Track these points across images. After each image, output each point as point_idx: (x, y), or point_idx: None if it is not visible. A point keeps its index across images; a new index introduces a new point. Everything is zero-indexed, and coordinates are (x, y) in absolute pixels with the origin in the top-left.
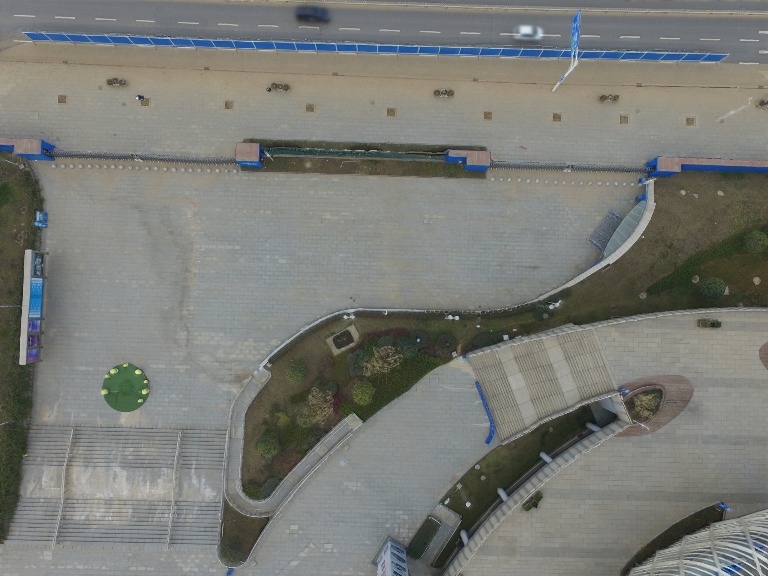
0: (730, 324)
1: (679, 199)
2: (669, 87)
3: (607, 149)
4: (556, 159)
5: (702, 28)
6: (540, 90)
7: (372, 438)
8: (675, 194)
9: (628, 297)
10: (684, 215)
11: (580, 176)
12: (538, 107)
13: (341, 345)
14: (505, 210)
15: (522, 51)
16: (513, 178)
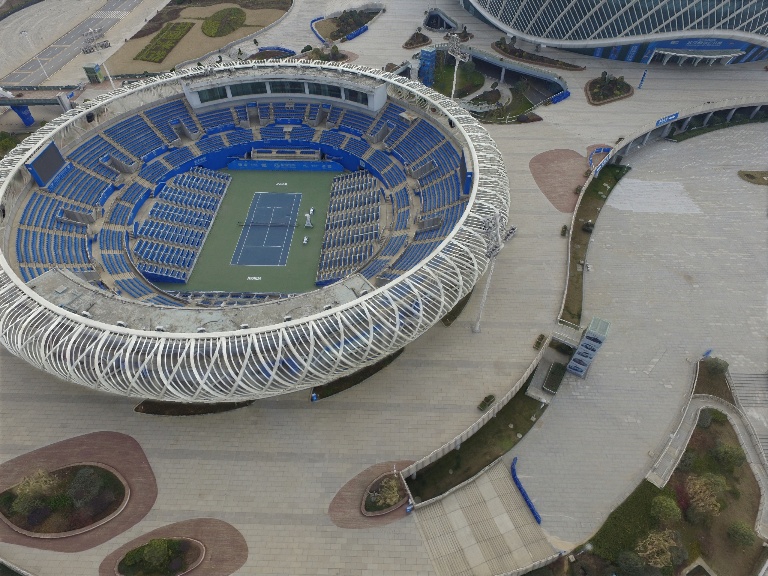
0: None
1: None
2: None
3: None
4: None
5: None
6: None
7: (630, 463)
8: None
9: None
10: None
11: None
12: None
13: (699, 571)
14: None
15: None
16: None
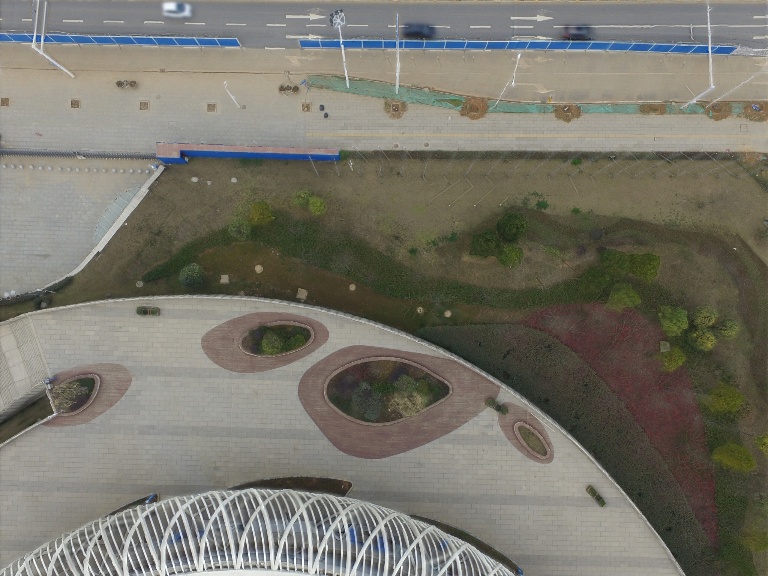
0: (172, 312)
1: (186, 186)
2: (192, 73)
3: (125, 136)
4: (72, 146)
5: (227, 13)
6: (60, 76)
7: None
8: (184, 181)
9: (123, 286)
10: (182, 202)
11: (95, 163)
12: (57, 93)
13: None
14: (17, 198)
15: (30, 36)
16: (26, 165)
